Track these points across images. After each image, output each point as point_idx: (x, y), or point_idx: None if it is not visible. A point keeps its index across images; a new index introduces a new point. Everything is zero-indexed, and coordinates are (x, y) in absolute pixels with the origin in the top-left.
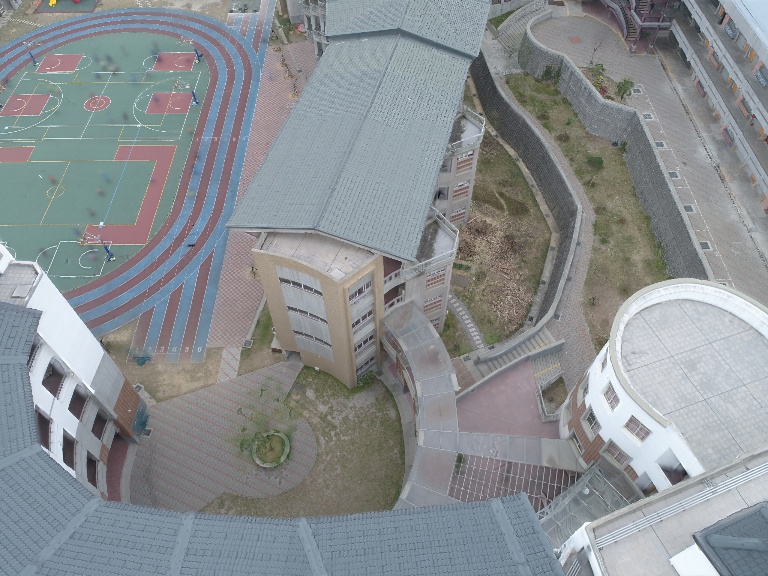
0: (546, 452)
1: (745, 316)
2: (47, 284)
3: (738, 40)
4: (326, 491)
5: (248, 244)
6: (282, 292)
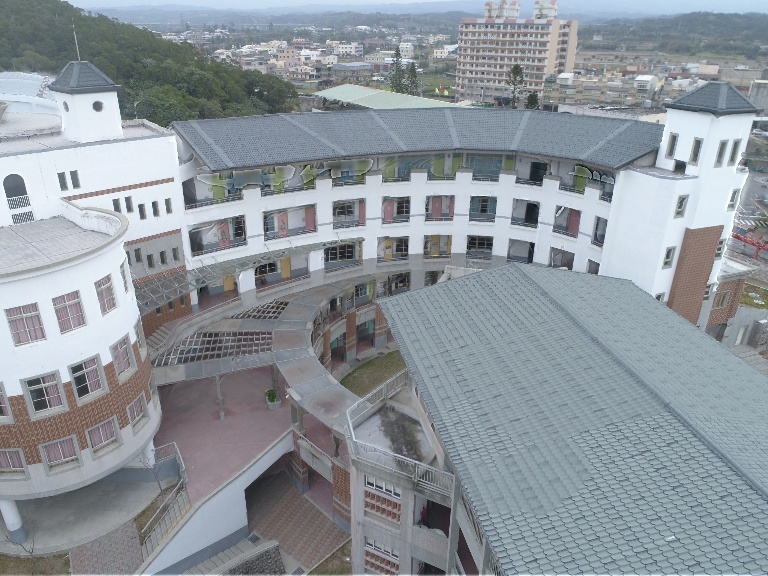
0: (180, 372)
1: None
2: (655, 188)
3: None
4: None
5: None
6: None
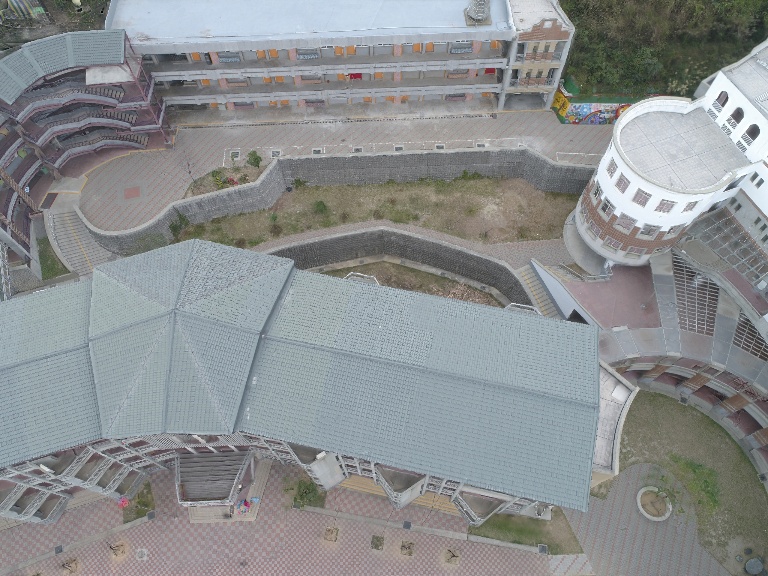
0: (663, 272)
1: None
2: None
3: (244, 57)
4: (675, 452)
5: (407, 574)
6: None
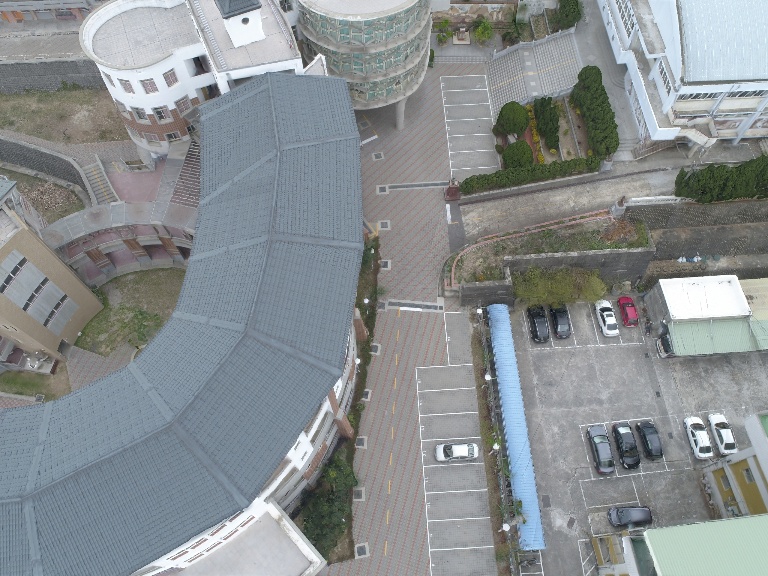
0: (176, 157)
1: (112, 14)
2: None
3: None
4: None
5: None
6: (10, 301)
